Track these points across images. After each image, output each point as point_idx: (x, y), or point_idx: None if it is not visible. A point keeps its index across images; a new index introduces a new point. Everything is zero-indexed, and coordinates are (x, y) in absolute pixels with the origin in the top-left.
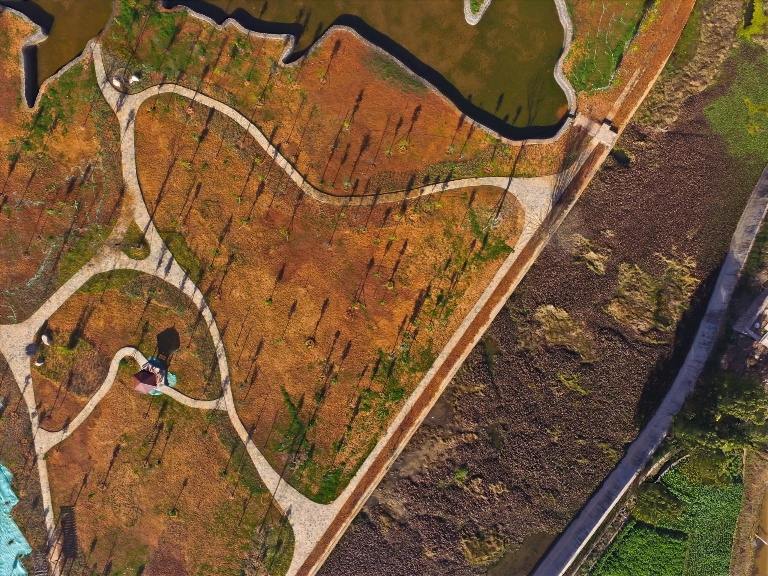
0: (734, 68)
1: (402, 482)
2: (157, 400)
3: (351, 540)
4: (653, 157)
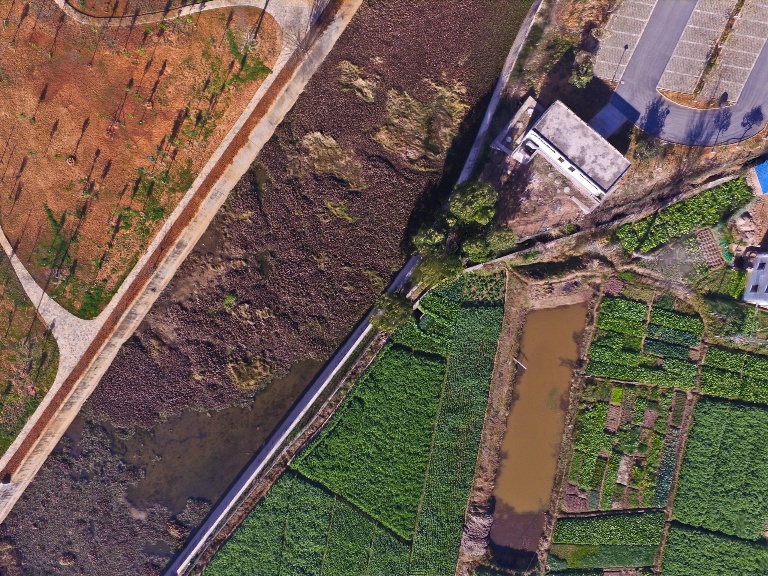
0: None
1: (172, 307)
2: None
3: (122, 362)
4: None
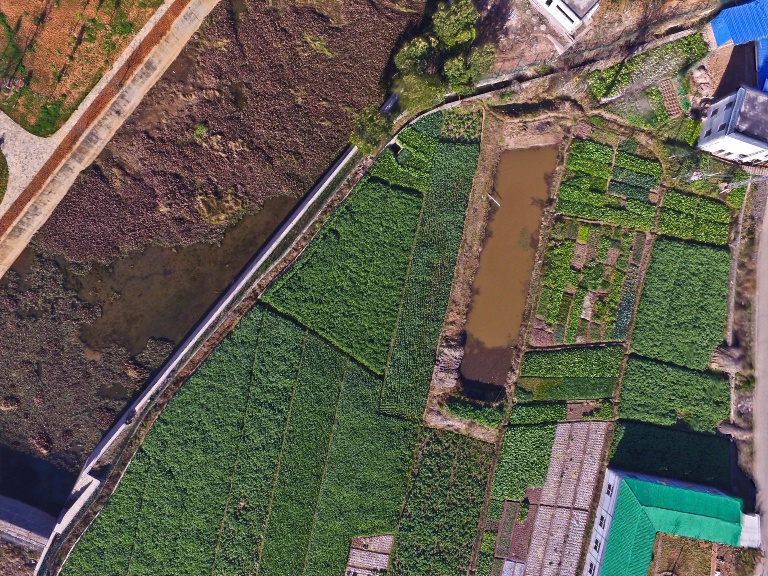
0: None
1: (138, 135)
2: None
3: (80, 191)
4: None
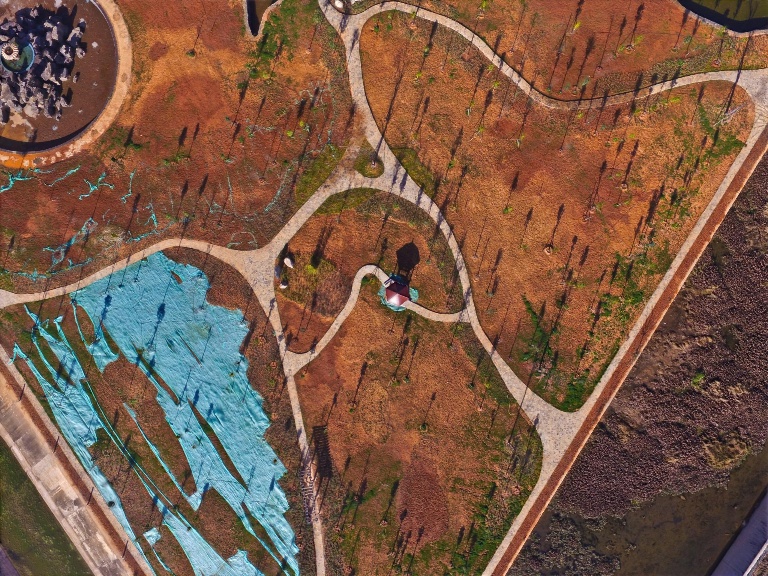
0: None
1: (638, 390)
2: (401, 316)
3: (591, 450)
4: None
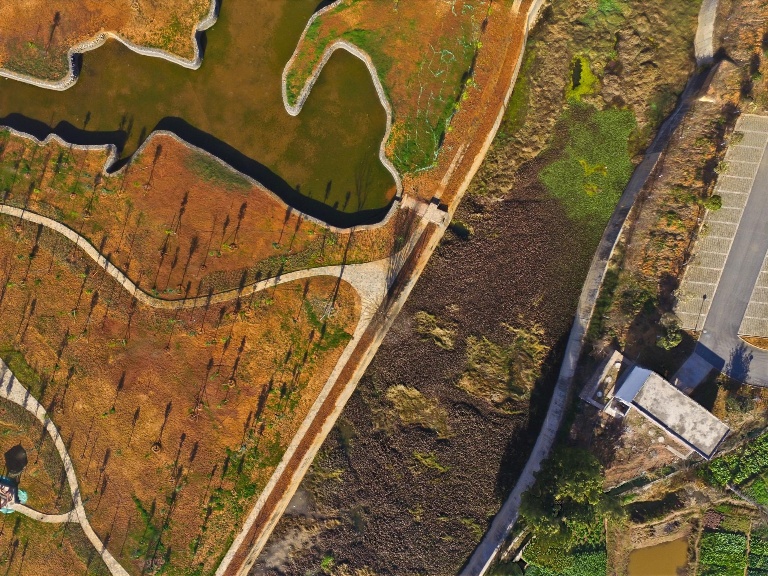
0: (566, 130)
1: (269, 573)
2: (10, 518)
3: None
4: (491, 227)
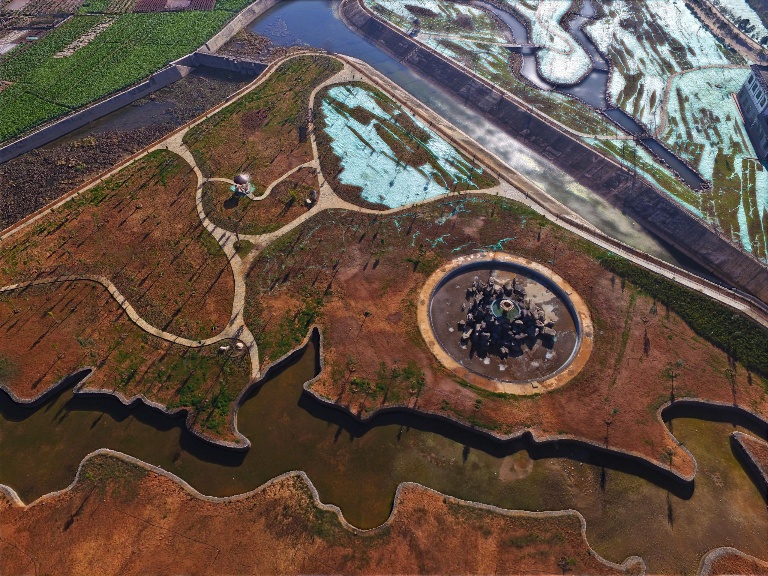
0: None
1: None
2: None
3: None
4: None
